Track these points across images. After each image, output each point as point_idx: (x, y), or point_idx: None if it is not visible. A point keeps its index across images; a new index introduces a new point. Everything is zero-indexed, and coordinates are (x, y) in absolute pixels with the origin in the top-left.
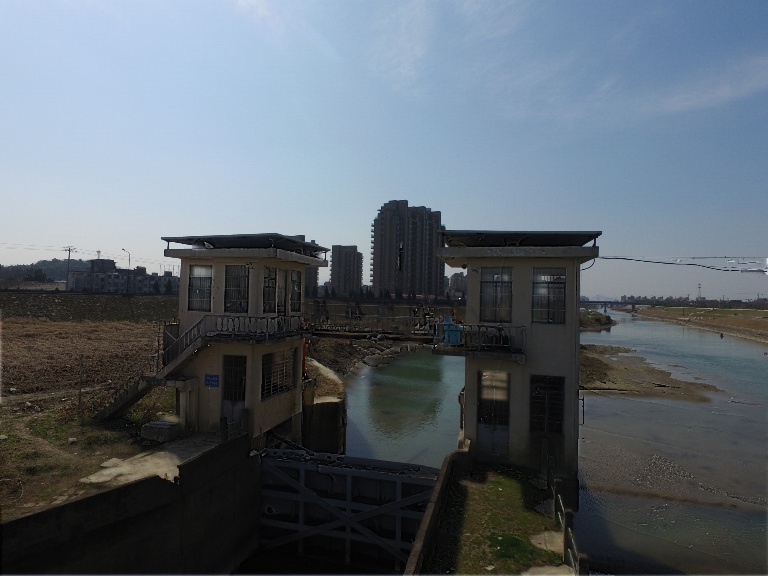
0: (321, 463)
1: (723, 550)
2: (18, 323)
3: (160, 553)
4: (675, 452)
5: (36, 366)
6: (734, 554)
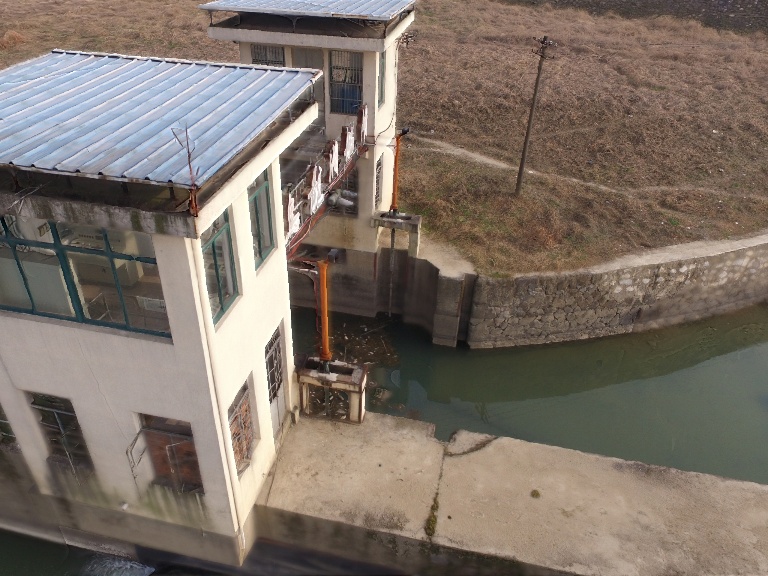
0: None
1: None
2: (655, 25)
3: None
4: None
5: (446, 93)
6: None
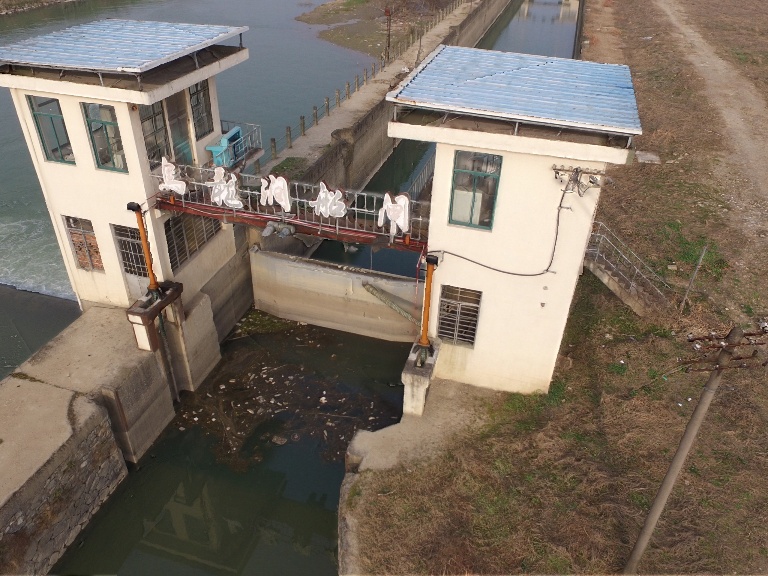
0: (366, 275)
1: None
2: None
3: None
4: None
5: None
6: None
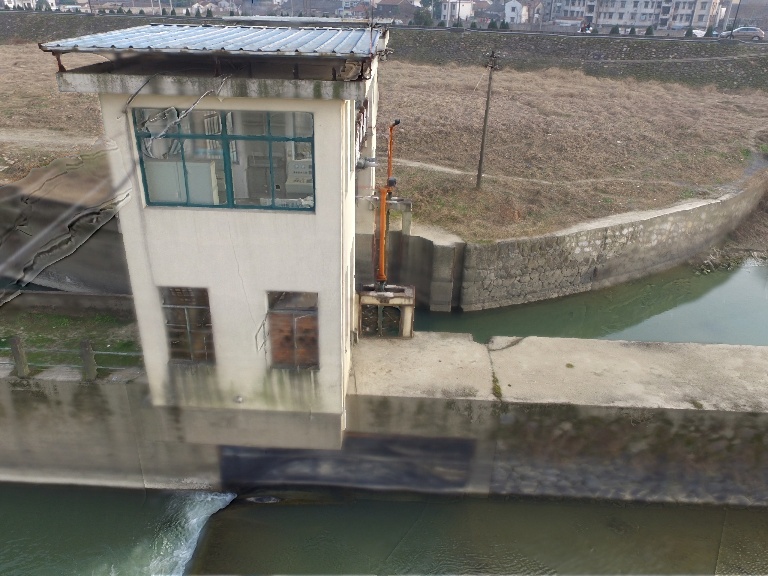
0: None
1: None
2: (547, 75)
3: (119, 259)
4: None
5: None
6: None
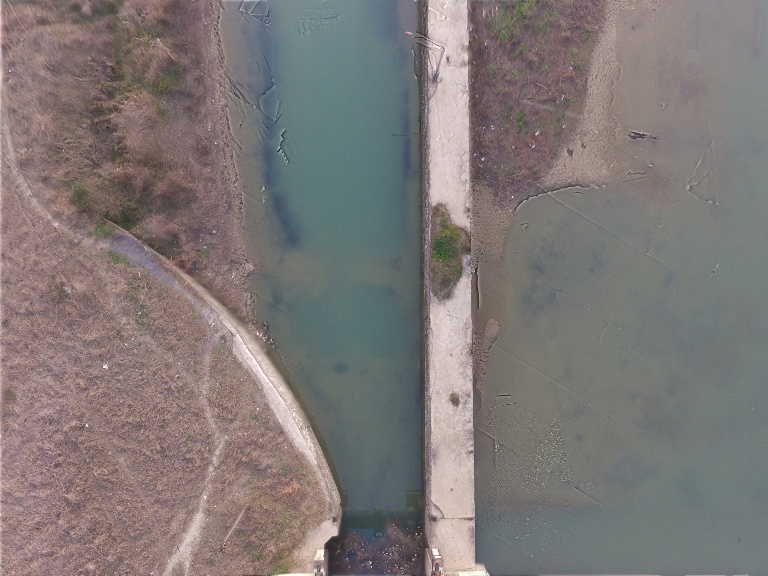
0: None
1: (545, 556)
2: None
3: None
4: (570, 408)
5: None
6: (549, 558)
